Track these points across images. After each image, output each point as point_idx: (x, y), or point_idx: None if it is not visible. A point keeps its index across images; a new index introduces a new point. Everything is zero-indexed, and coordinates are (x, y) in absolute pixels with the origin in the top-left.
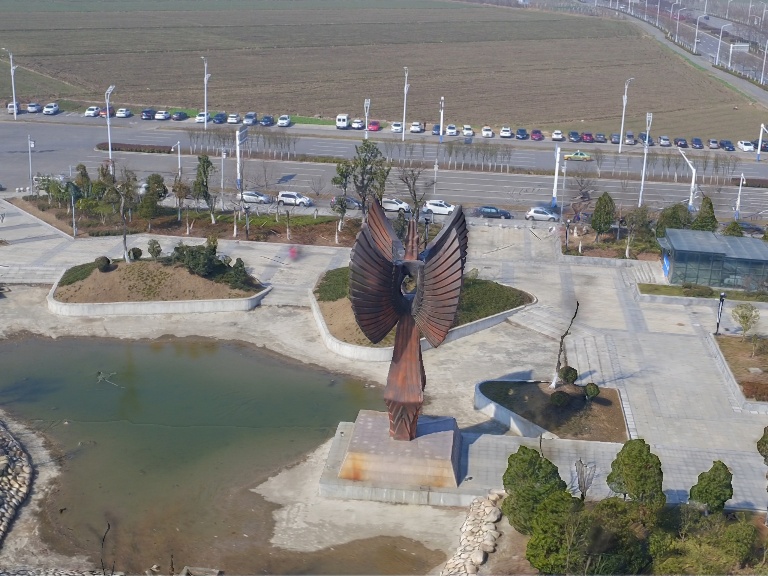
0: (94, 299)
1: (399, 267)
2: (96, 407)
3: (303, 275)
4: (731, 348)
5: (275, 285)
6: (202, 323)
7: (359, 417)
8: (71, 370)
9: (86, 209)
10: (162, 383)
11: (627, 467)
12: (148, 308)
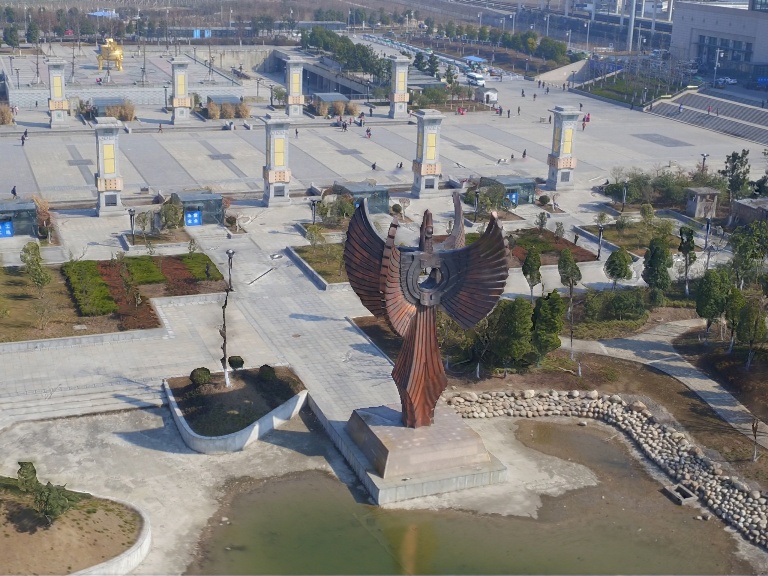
0: None
1: None
2: None
3: None
4: (21, 337)
5: None
6: None
7: (408, 447)
8: None
9: None
10: None
11: None
12: None
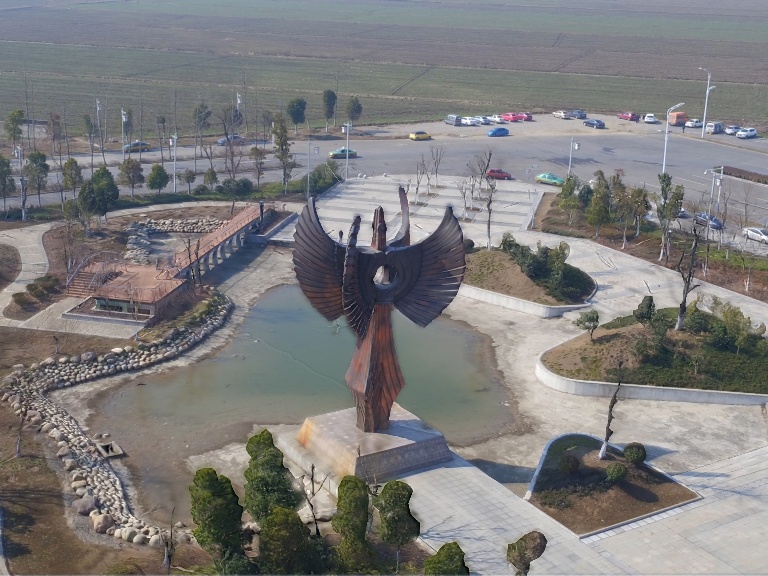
0: None
1: None
2: (297, 340)
3: None
4: None
5: (598, 305)
6: (489, 315)
7: None
8: None
9: (565, 209)
10: None
11: None
12: (465, 291)
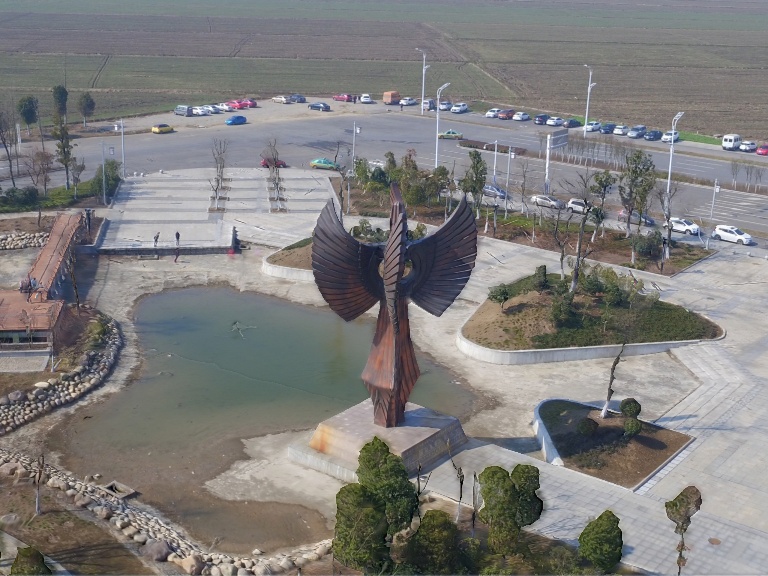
0: (296, 264)
1: (371, 248)
2: (208, 349)
3: (506, 275)
4: None
5: None
6: None
7: (369, 398)
8: (225, 318)
9: (372, 191)
10: (282, 342)
11: (481, 486)
12: None
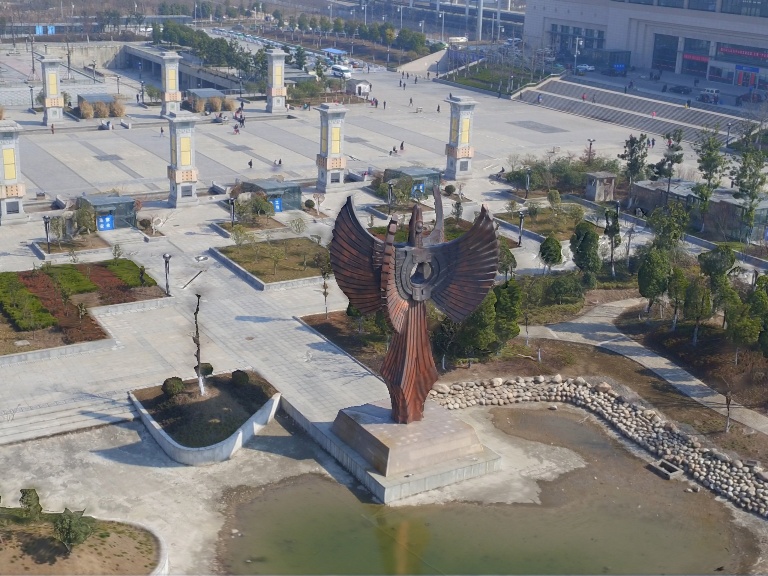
0: None
1: None
2: None
3: None
4: None
5: None
6: None
7: (407, 444)
8: None
9: None
10: None
11: None
12: None
